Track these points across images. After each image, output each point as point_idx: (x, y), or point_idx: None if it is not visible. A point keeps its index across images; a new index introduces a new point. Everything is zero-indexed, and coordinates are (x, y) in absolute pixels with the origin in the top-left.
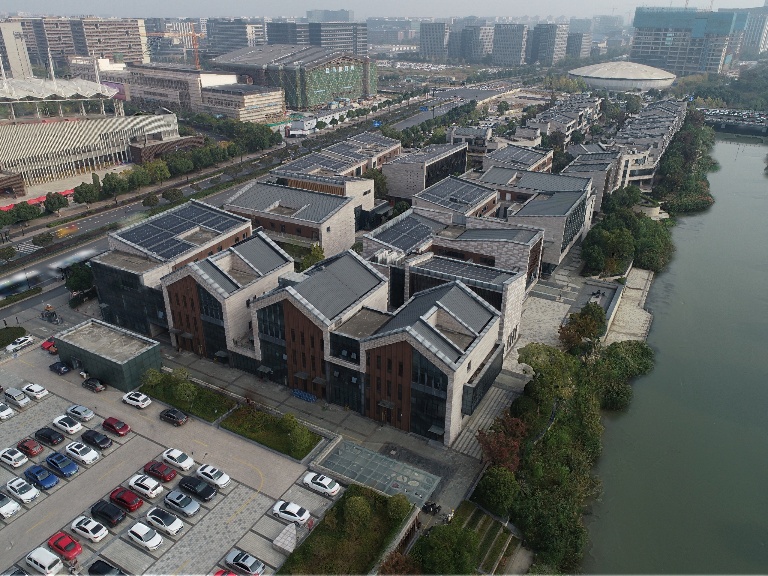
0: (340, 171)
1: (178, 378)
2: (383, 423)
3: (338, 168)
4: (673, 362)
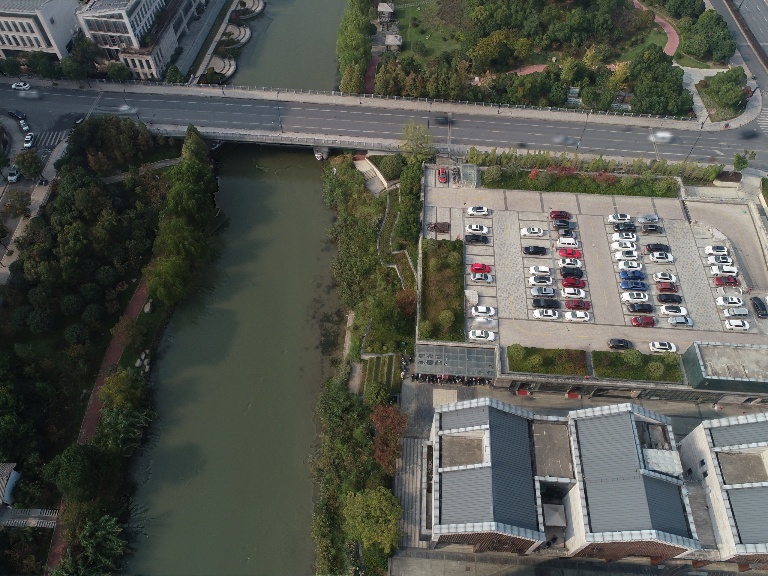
0: None
1: None
2: None
3: None
4: None
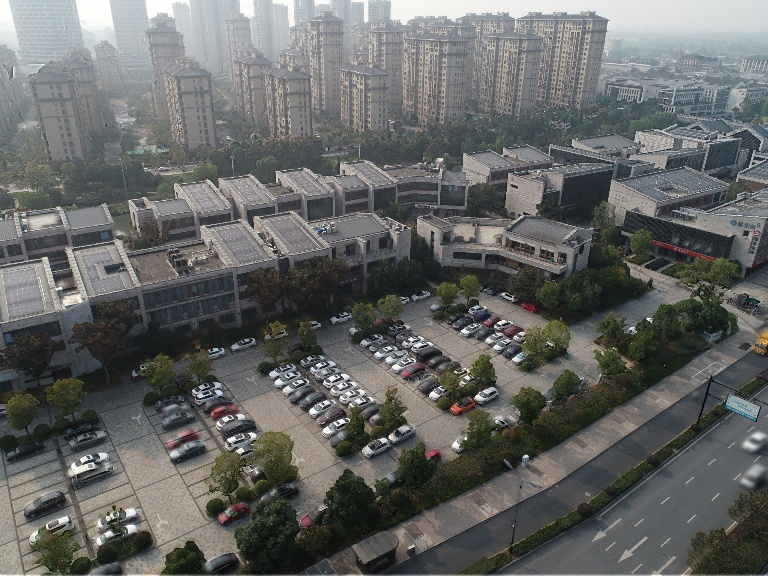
0: None
1: None
2: None
3: None
4: None
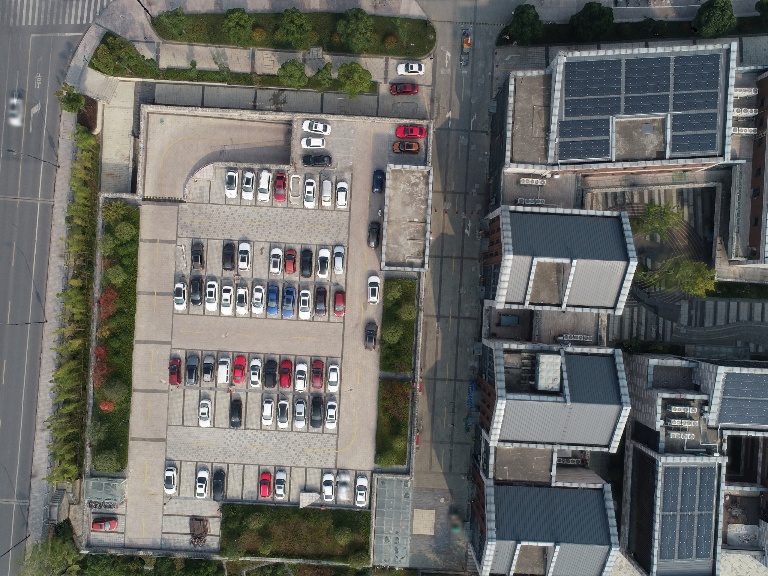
0: None
1: (402, 316)
2: (471, 477)
3: None
4: None
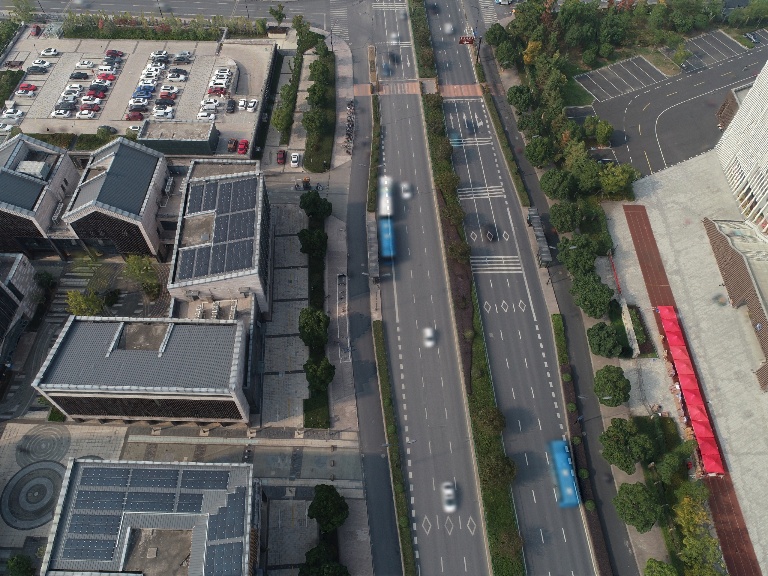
0: None
1: None
2: None
3: None
4: None
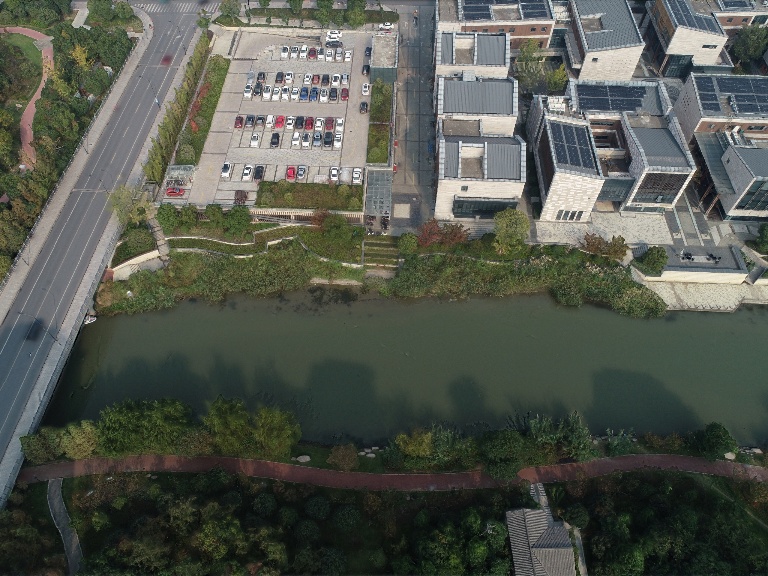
0: (725, 11)
1: (383, 91)
2: None
3: (731, 6)
4: (660, 332)
